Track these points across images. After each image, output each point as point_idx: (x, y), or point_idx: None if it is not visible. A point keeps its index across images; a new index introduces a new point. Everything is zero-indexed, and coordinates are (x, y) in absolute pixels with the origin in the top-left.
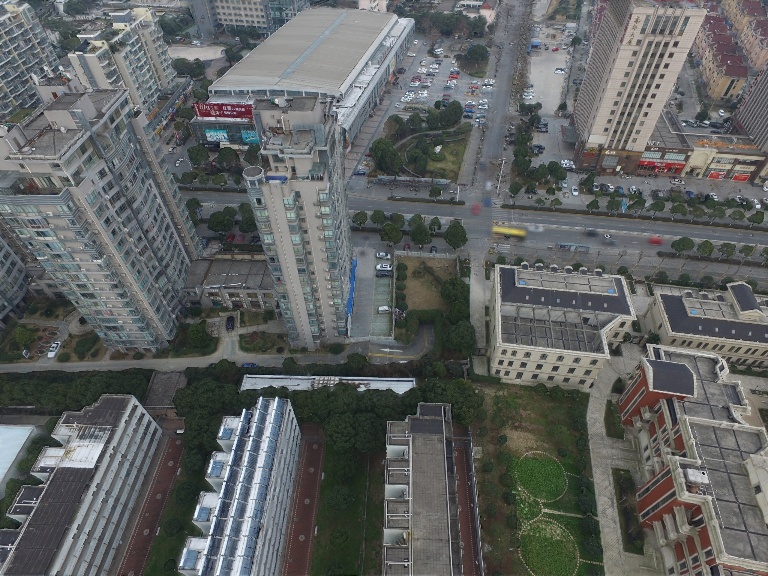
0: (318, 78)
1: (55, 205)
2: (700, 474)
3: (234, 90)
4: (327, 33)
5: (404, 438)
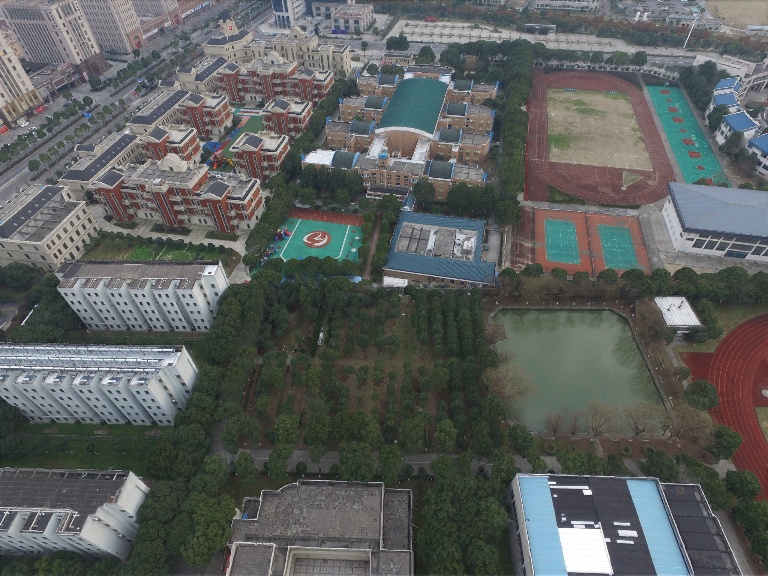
0: None
1: None
2: (156, 180)
3: None
4: None
5: (73, 280)
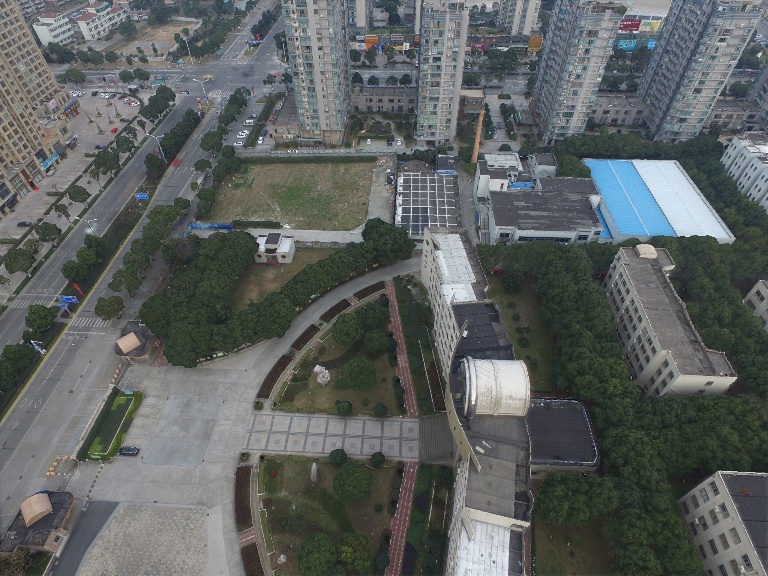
0: (656, 8)
1: (751, 19)
2: None
3: None
4: None
5: None
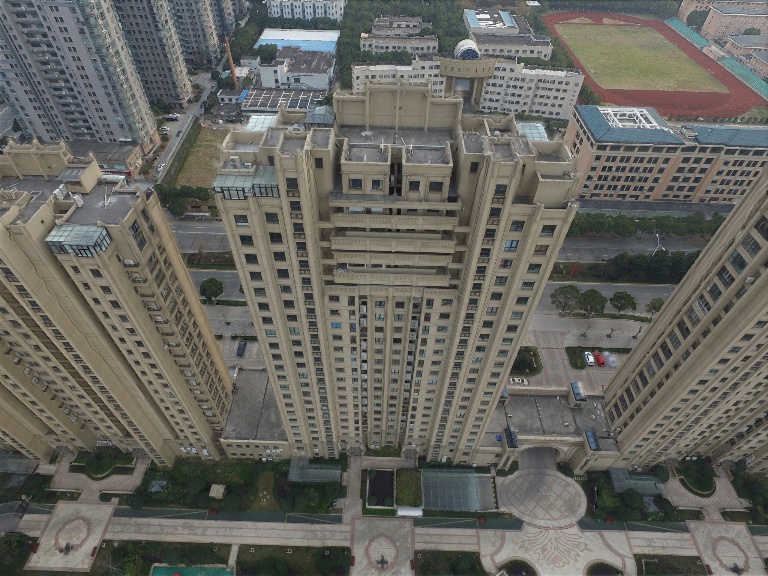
0: None
1: None
2: None
3: None
4: None
5: None
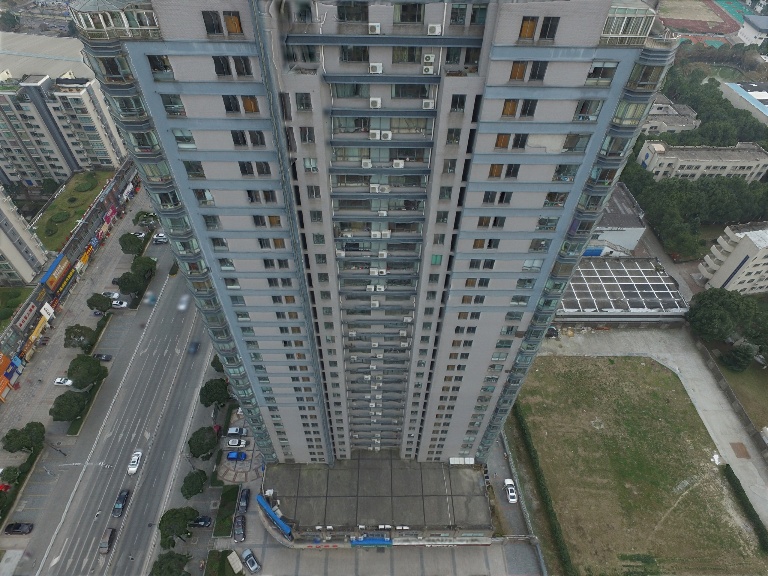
0: None
1: None
2: None
3: None
4: (6, 51)
5: None
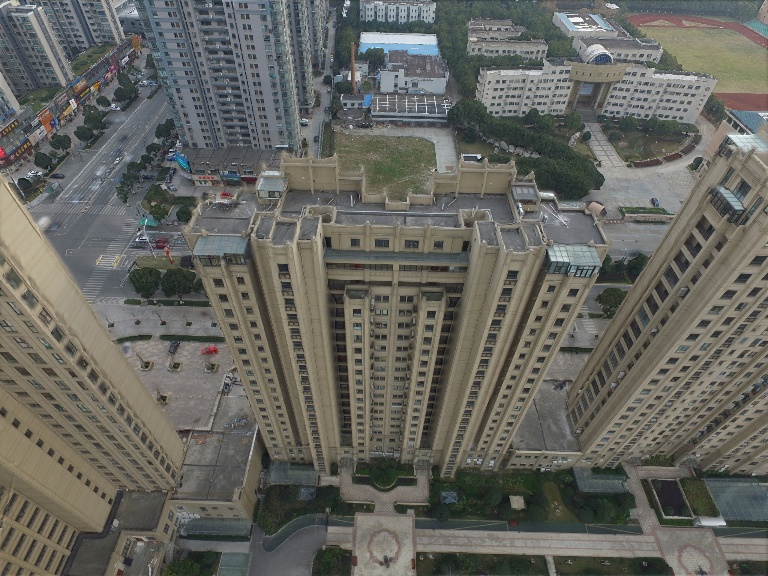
0: None
1: None
2: None
3: (121, 4)
4: None
5: None
